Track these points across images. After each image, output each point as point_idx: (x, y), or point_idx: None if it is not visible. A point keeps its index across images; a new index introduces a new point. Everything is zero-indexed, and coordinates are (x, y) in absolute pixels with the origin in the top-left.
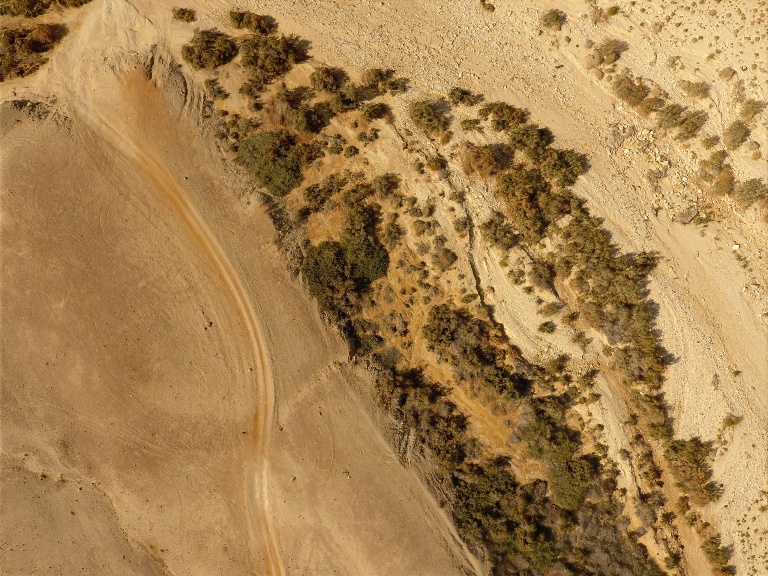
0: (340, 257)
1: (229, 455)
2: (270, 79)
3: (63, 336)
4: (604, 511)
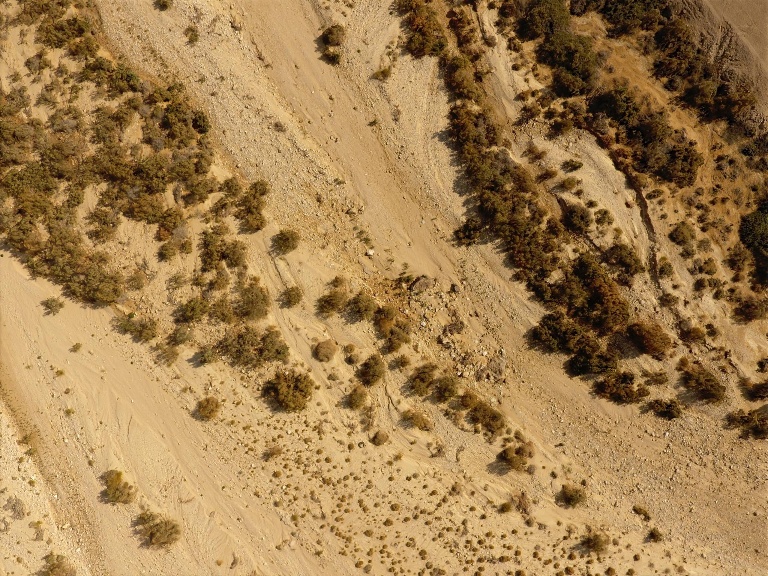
0: None
1: None
2: None
3: None
4: None
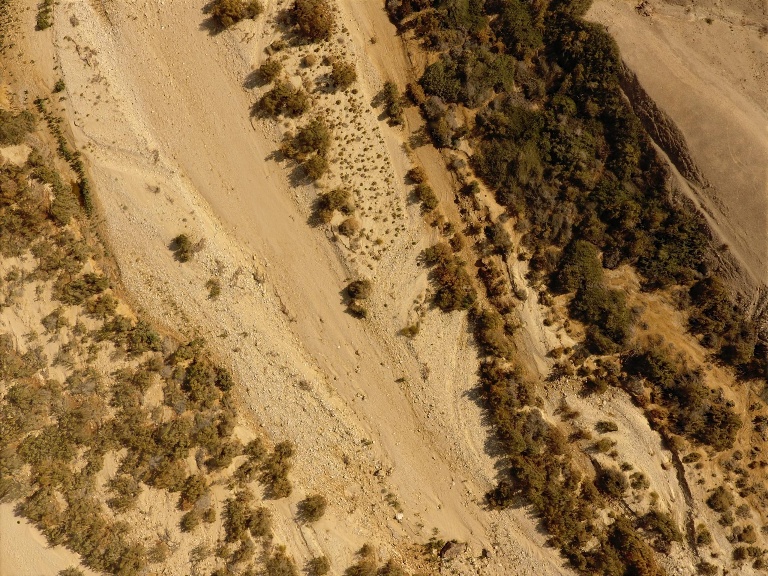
0: None
1: None
2: None
3: None
4: (547, 240)
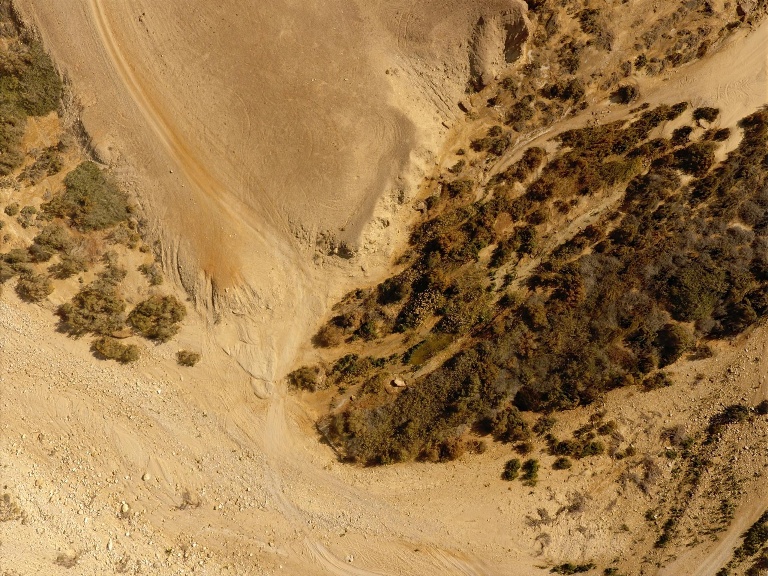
0: None
1: None
2: None
3: (280, 2)
4: None
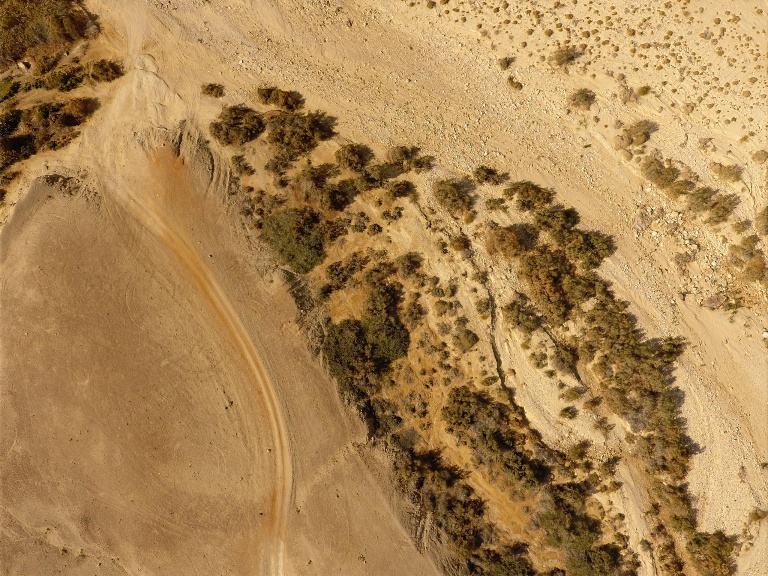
0: (361, 336)
1: (246, 536)
2: (296, 156)
3: (87, 413)
4: None
